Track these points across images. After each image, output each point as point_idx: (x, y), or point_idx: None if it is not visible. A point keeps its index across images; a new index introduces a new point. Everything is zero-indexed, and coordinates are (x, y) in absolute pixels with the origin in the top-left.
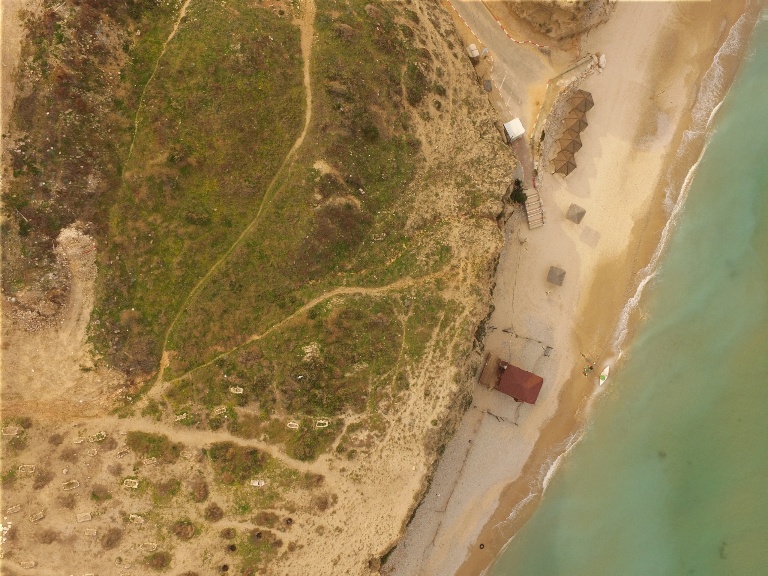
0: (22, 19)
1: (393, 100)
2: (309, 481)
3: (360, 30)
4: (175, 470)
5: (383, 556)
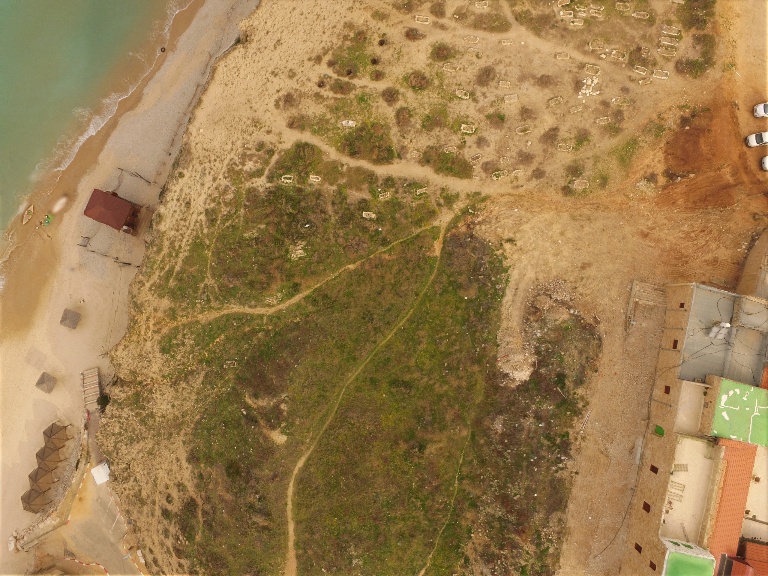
0: None
1: (211, 505)
2: (301, 123)
3: None
4: (427, 140)
5: (235, 46)
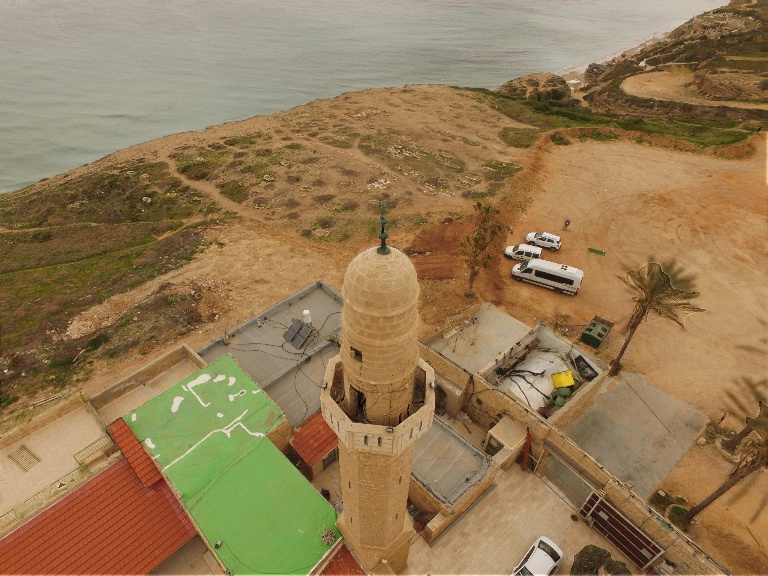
0: None
1: None
2: None
3: None
4: (236, 177)
5: None
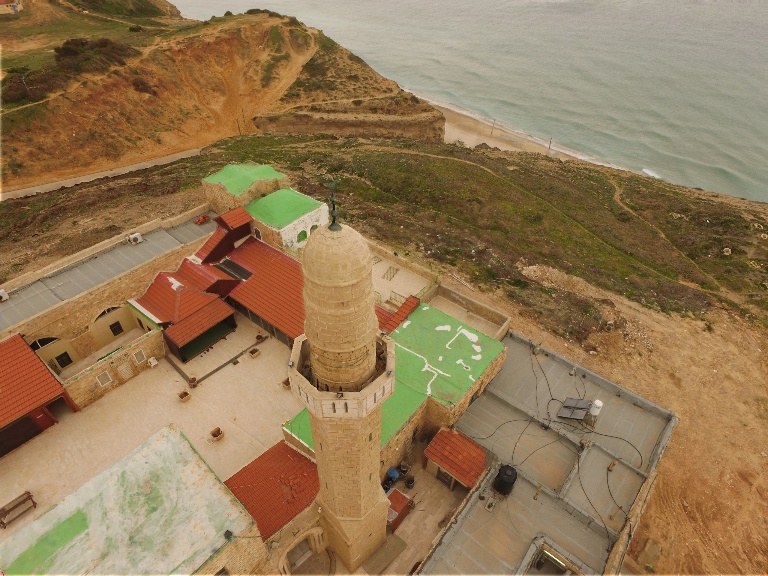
0: None
1: None
2: None
3: None
4: None
5: None
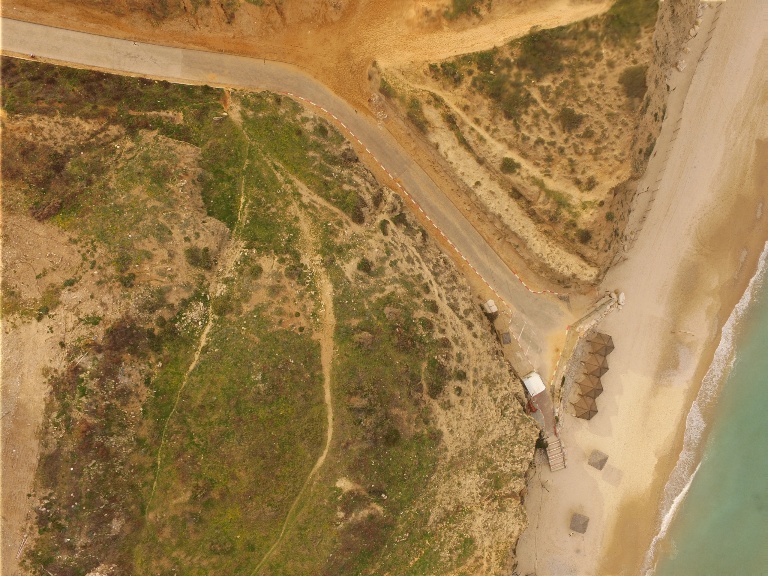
0: (46, 376)
1: (414, 398)
2: None
3: (380, 334)
4: None
5: None
